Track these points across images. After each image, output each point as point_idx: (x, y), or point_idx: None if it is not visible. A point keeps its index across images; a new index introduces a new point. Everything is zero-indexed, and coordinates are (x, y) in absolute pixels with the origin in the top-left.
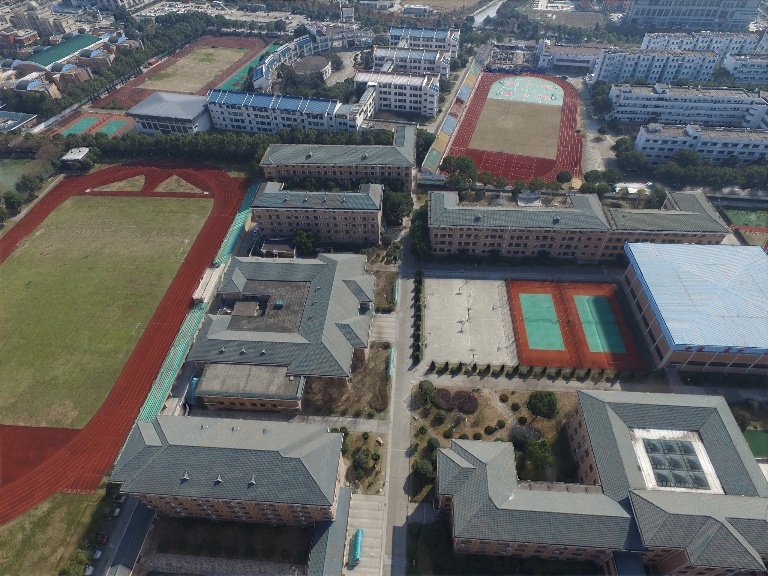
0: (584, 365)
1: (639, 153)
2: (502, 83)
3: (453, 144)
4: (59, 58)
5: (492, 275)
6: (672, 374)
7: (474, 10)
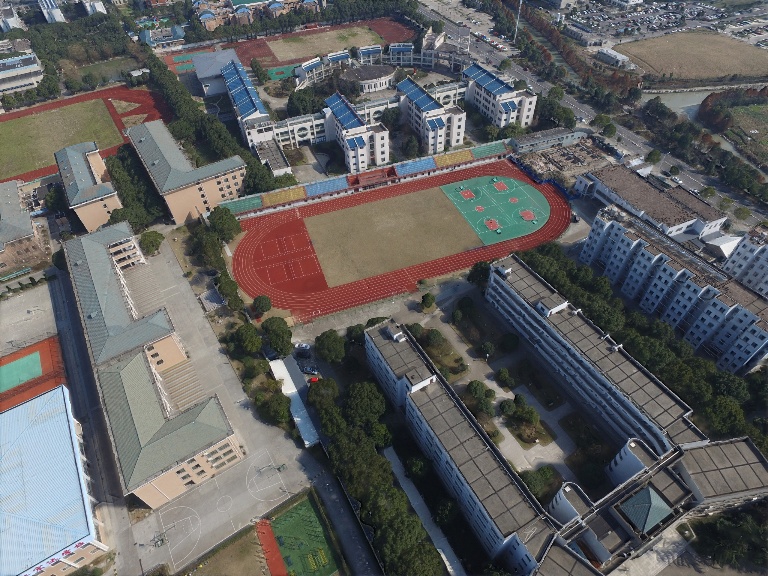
0: None
1: (332, 343)
2: (493, 181)
3: (303, 207)
4: (250, 2)
5: (65, 322)
6: None
7: (694, 85)
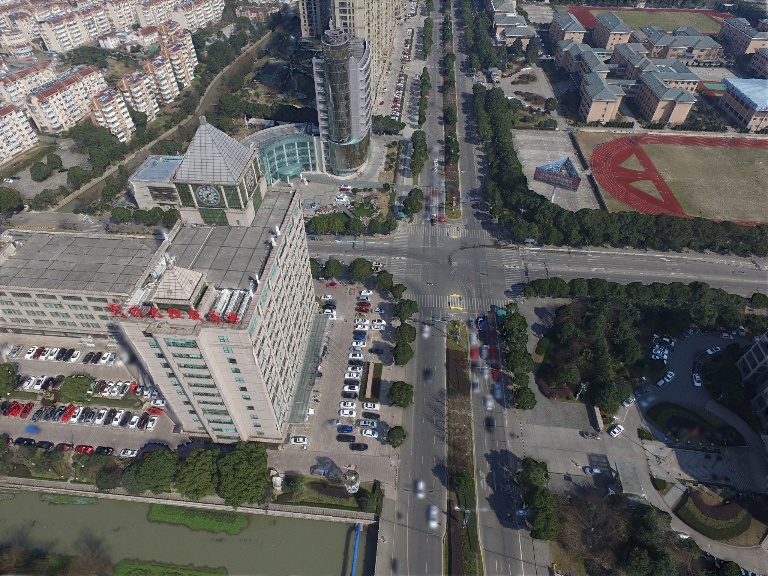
0: (704, 91)
1: None
2: None
3: None
4: None
5: None
6: None
7: None
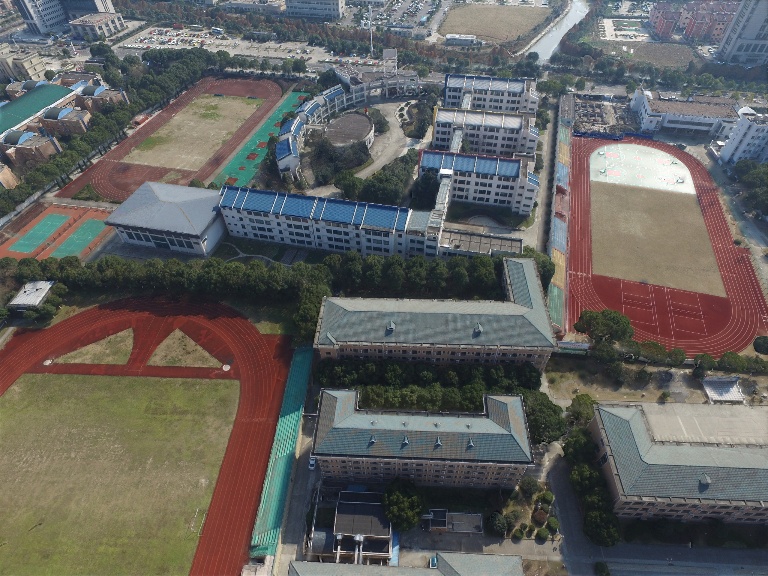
0: None
1: None
2: (602, 155)
3: (570, 266)
4: (15, 123)
5: (724, 572)
6: None
7: (529, 40)
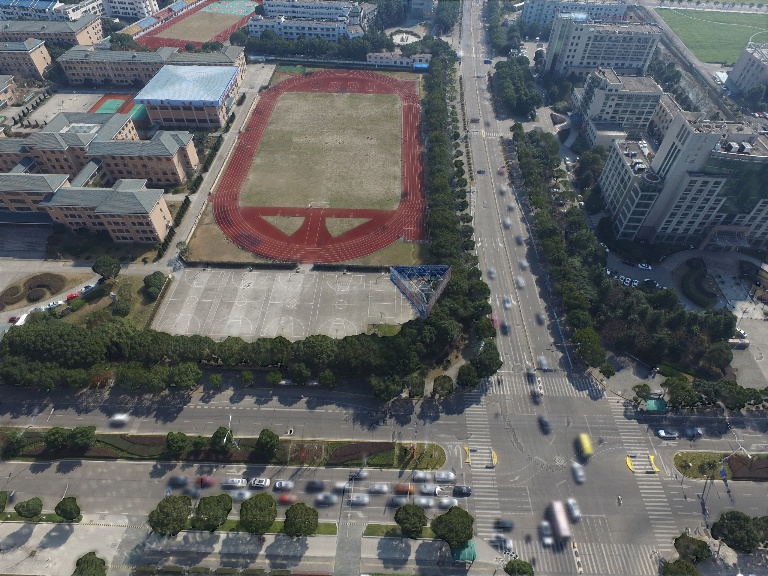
0: None
1: (239, 32)
2: (219, 3)
3: (145, 34)
4: None
5: (100, 92)
6: (157, 127)
7: None
